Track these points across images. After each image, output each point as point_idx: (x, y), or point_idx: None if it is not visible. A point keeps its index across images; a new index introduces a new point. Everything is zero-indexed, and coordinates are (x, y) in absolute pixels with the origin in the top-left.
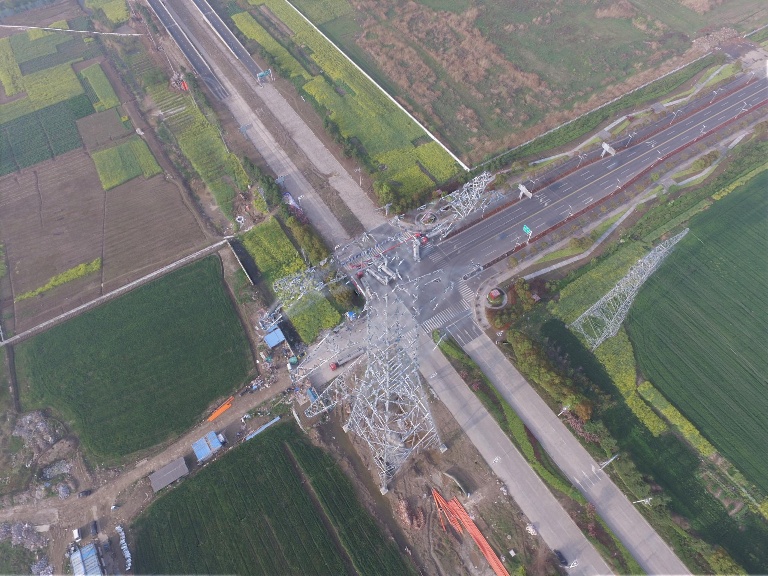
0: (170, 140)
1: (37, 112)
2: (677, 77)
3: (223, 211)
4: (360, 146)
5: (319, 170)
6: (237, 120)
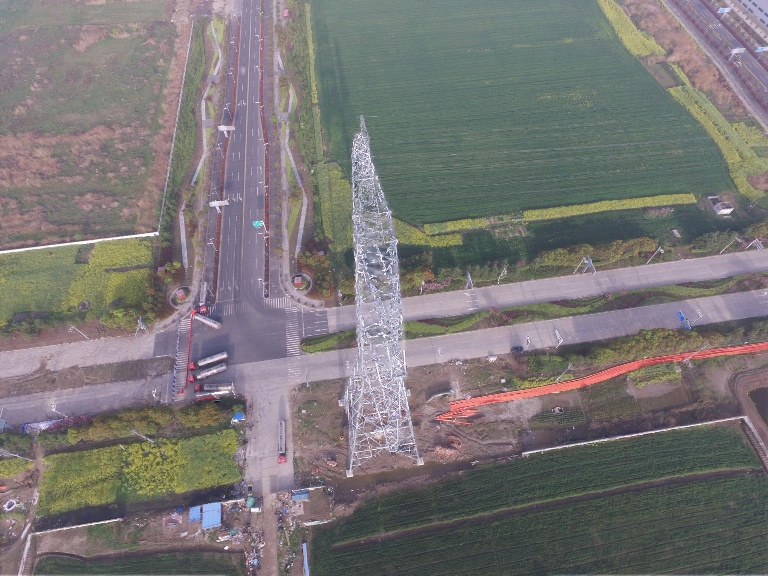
0: None
1: None
2: (196, 51)
3: None
4: (33, 315)
5: (24, 374)
6: None
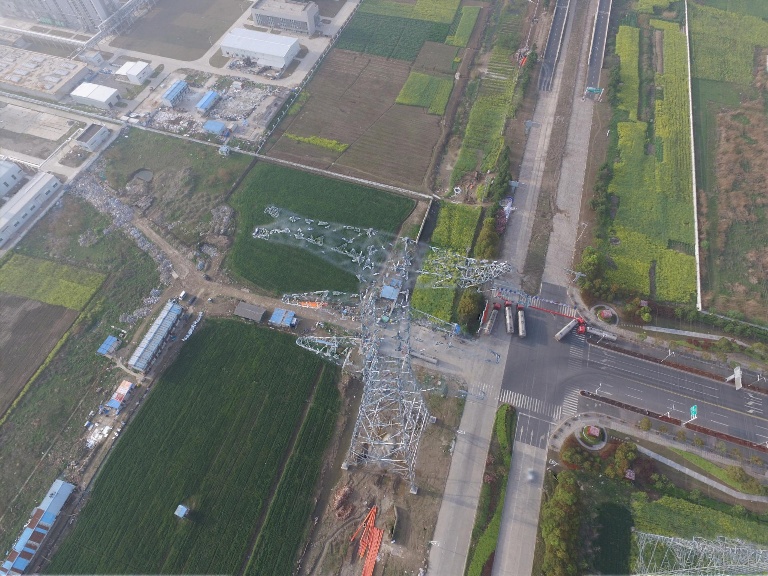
0: (471, 96)
1: (410, 20)
2: None
3: (452, 175)
4: (615, 208)
5: (557, 200)
6: (535, 114)
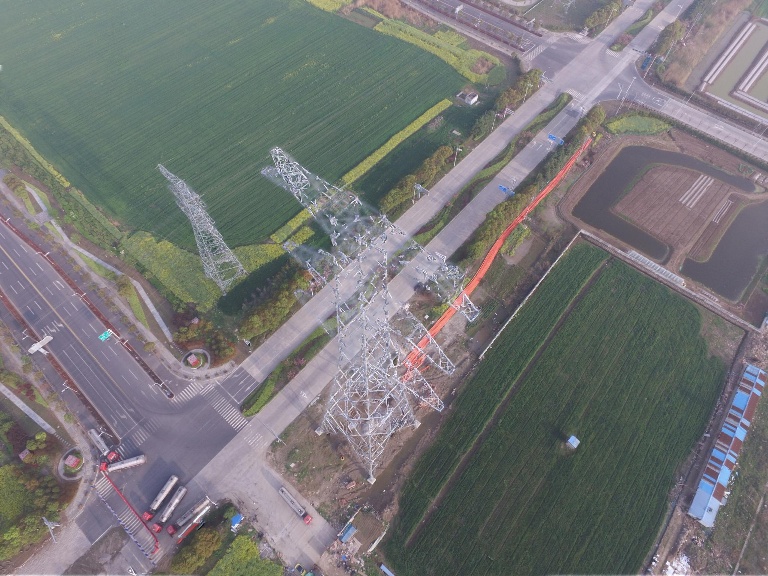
0: None
1: None
2: None
3: None
4: None
5: None
6: None
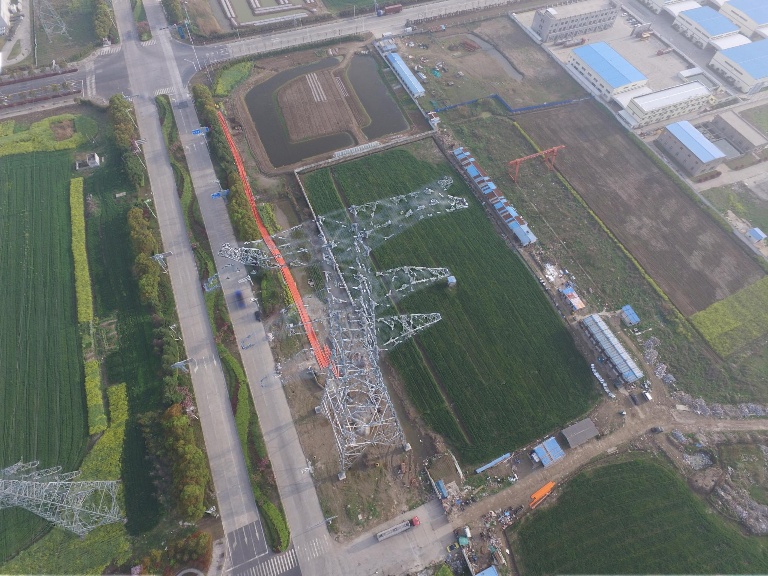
0: None
1: None
2: None
3: None
4: None
5: None
6: None
